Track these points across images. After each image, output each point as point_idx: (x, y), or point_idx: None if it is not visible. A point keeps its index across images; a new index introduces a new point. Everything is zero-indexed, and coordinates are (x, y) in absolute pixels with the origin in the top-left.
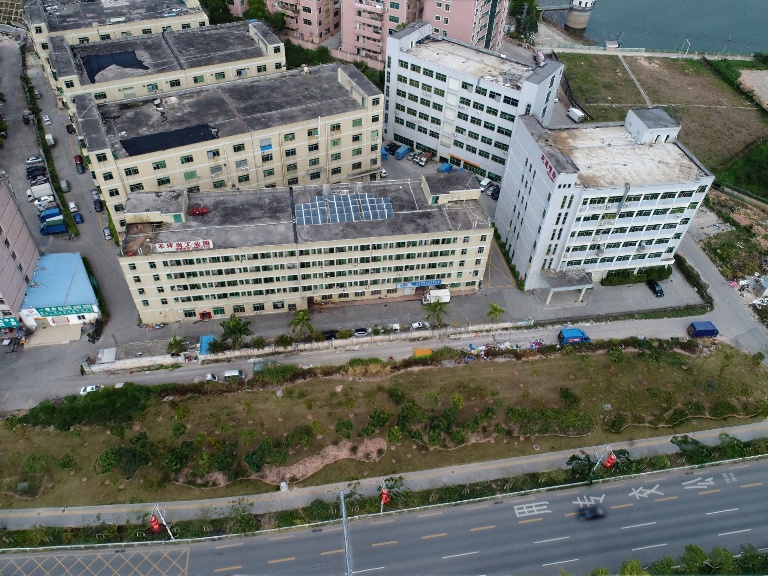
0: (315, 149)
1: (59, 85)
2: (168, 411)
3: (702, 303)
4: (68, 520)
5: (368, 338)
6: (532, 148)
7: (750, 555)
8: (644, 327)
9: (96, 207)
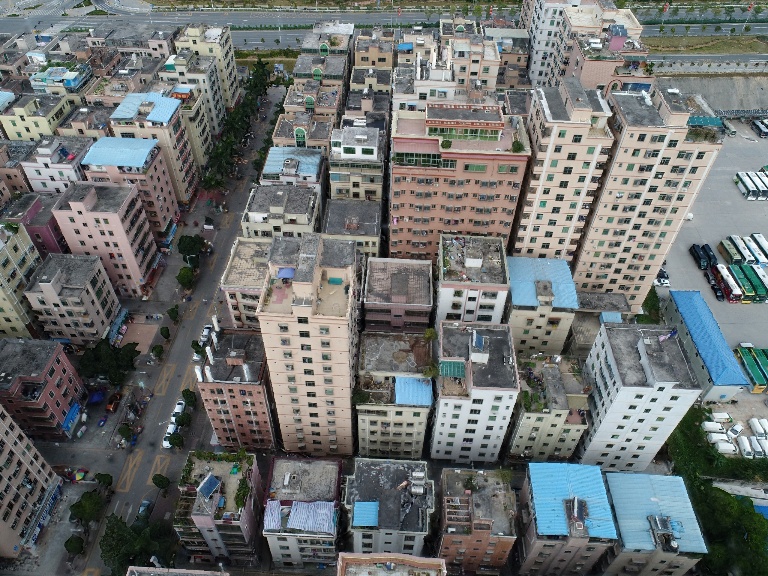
0: None
1: None
2: None
3: None
4: (279, 7)
5: None
6: None
7: None
8: None
9: None
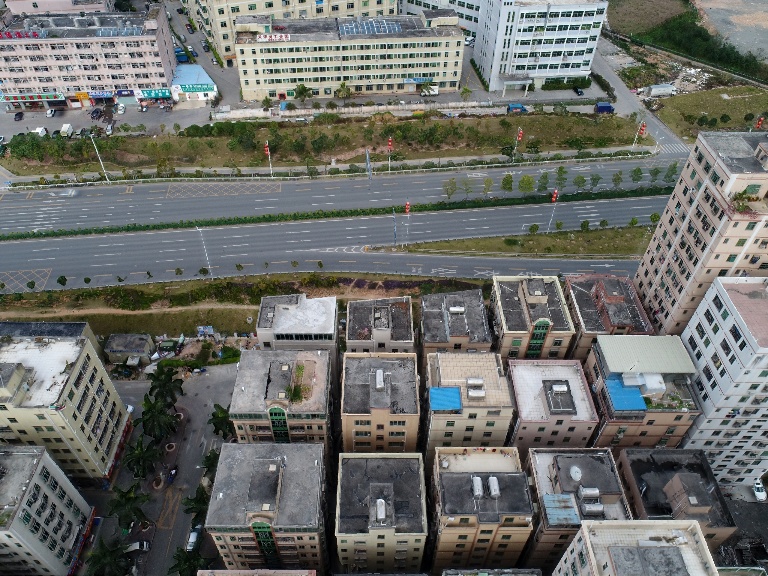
0: (351, 7)
1: None
2: (264, 133)
3: (607, 97)
4: None
5: (384, 107)
6: None
7: None
8: None
9: (205, 48)
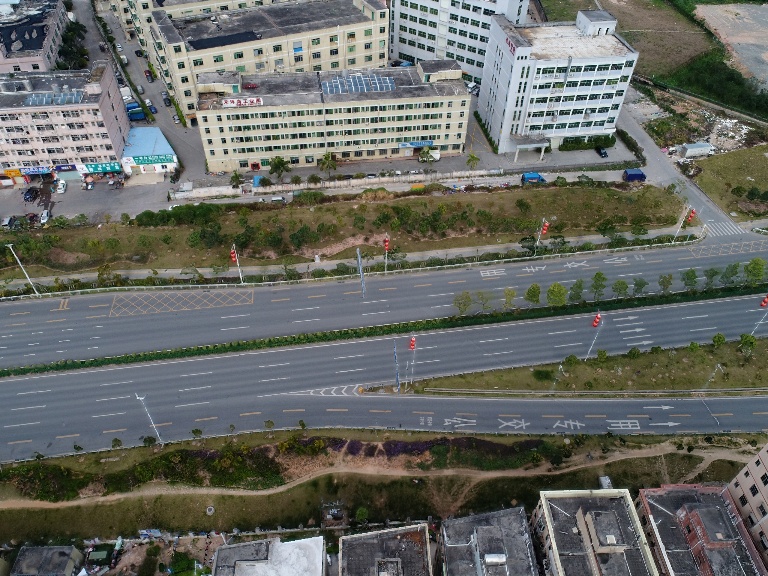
0: (335, 54)
1: (133, 12)
2: (233, 219)
3: (636, 160)
4: None
5: (377, 179)
6: (500, 36)
7: (640, 283)
8: (589, 176)
9: (166, 102)
